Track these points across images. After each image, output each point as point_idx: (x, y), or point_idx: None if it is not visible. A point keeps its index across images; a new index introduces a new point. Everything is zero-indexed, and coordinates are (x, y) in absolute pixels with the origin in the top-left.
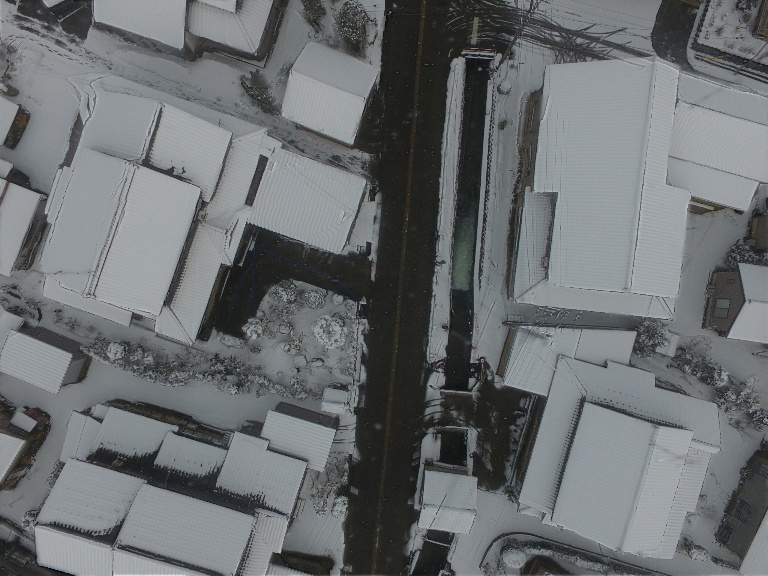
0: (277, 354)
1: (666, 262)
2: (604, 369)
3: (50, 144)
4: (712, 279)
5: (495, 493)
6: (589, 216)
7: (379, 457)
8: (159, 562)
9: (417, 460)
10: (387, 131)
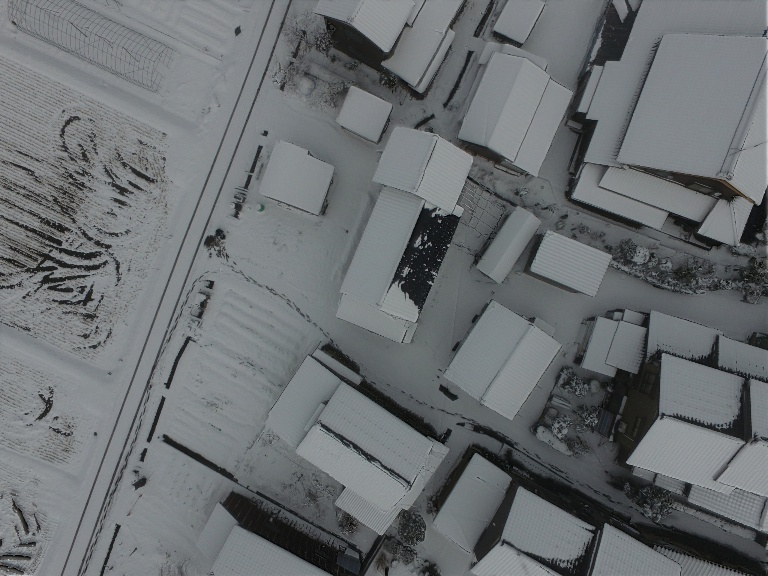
0: None
1: None
2: None
3: (556, 46)
4: None
5: None
6: None
7: None
8: None
9: None
10: None
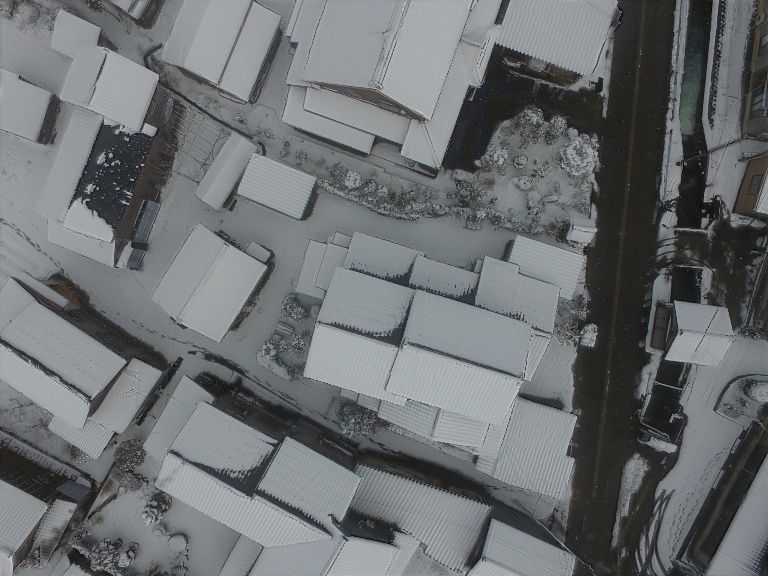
0: (508, 190)
1: None
2: None
3: None
4: None
5: None
6: None
7: (610, 298)
8: (450, 358)
9: (649, 301)
10: None
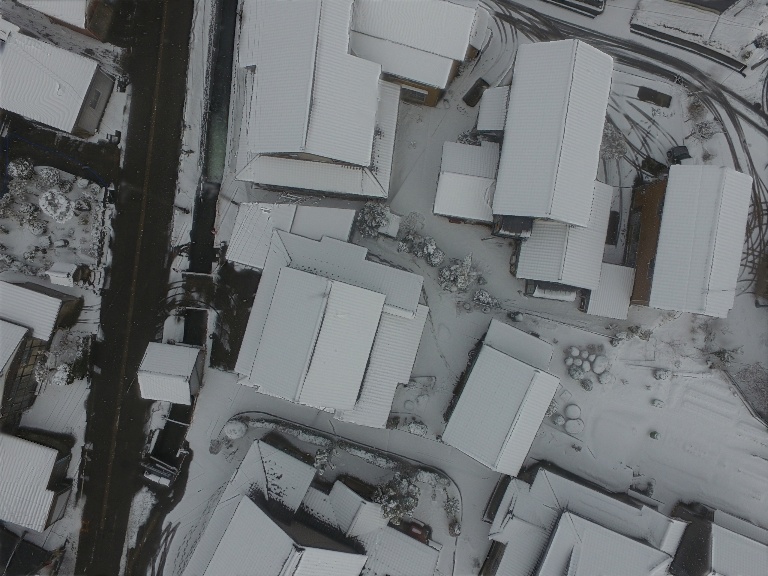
0: (25, 235)
1: (352, 129)
2: (317, 242)
3: None
4: None
5: (232, 373)
6: (277, 84)
7: (122, 337)
8: None
9: (159, 341)
10: (138, 26)
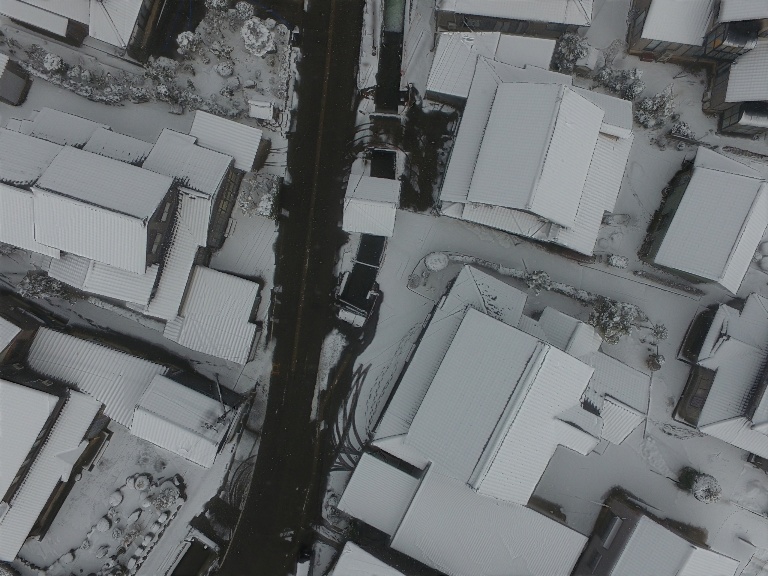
0: (211, 78)
1: None
2: (522, 69)
3: None
4: (633, 6)
5: (422, 214)
6: None
7: (310, 180)
8: (76, 201)
9: None
10: None
